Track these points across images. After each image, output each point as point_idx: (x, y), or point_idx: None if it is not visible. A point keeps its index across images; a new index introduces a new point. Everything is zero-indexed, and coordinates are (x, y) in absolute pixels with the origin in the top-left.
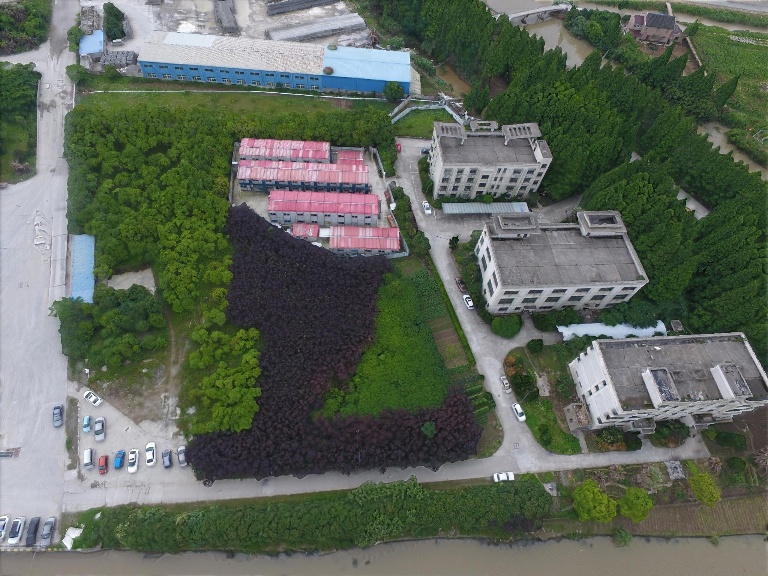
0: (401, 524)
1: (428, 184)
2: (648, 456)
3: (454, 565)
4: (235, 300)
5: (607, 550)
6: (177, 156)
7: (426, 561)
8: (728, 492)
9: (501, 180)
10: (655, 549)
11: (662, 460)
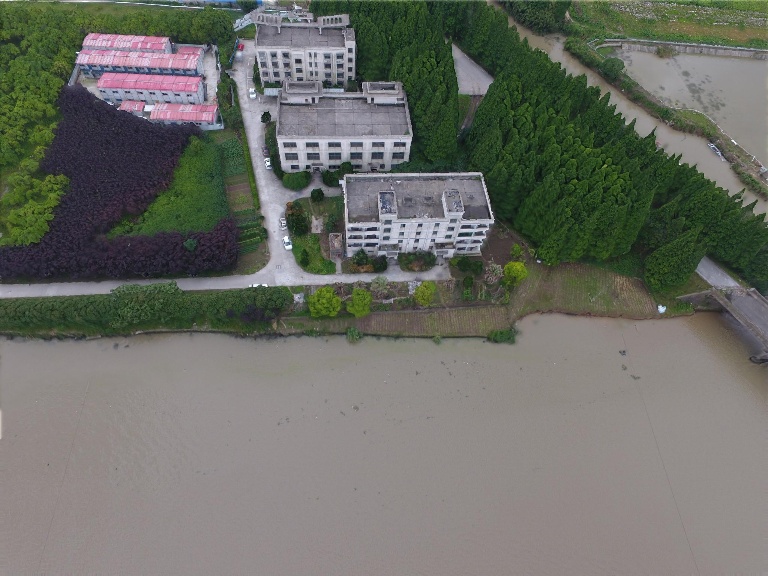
0: (149, 310)
1: (254, 72)
2: (394, 277)
3: (202, 351)
4: (52, 154)
5: (340, 344)
6: (26, 46)
7: (178, 347)
8: (457, 304)
9: (316, 66)
10: (383, 345)
11: (406, 280)
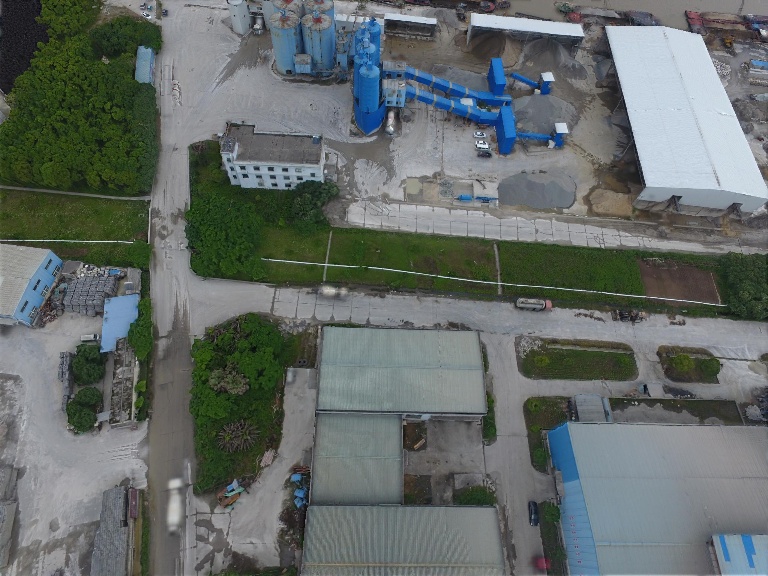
0: None
1: None
2: None
3: None
4: None
5: None
6: None
7: None
8: None
9: None
10: None
11: None
